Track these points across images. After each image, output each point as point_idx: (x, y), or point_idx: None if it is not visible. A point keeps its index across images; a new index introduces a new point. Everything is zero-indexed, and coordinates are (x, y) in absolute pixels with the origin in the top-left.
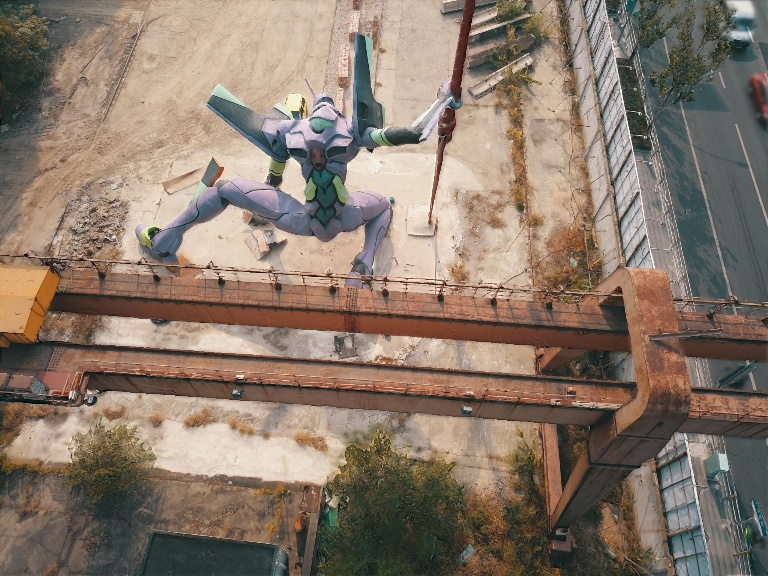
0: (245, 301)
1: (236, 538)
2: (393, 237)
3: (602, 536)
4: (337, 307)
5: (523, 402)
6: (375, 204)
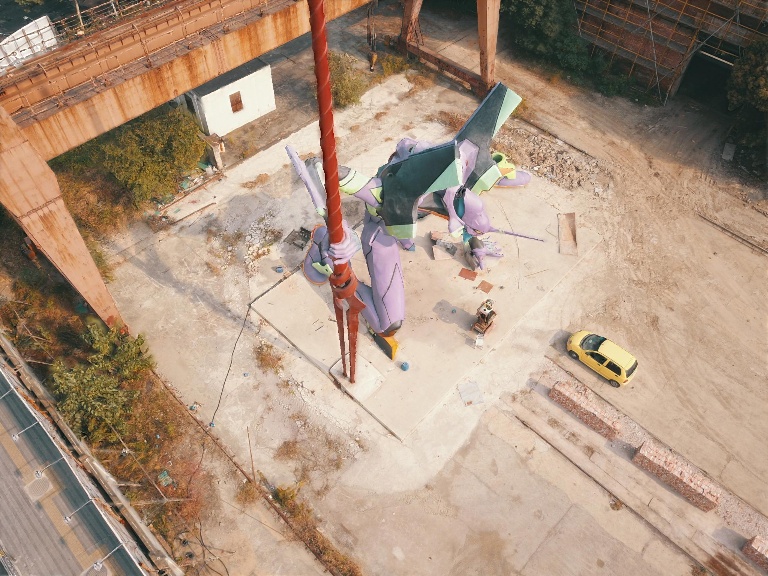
0: (271, 2)
1: (247, 128)
2: (361, 337)
3: (7, 279)
4: (214, 28)
5: (43, 54)
6: (377, 285)
